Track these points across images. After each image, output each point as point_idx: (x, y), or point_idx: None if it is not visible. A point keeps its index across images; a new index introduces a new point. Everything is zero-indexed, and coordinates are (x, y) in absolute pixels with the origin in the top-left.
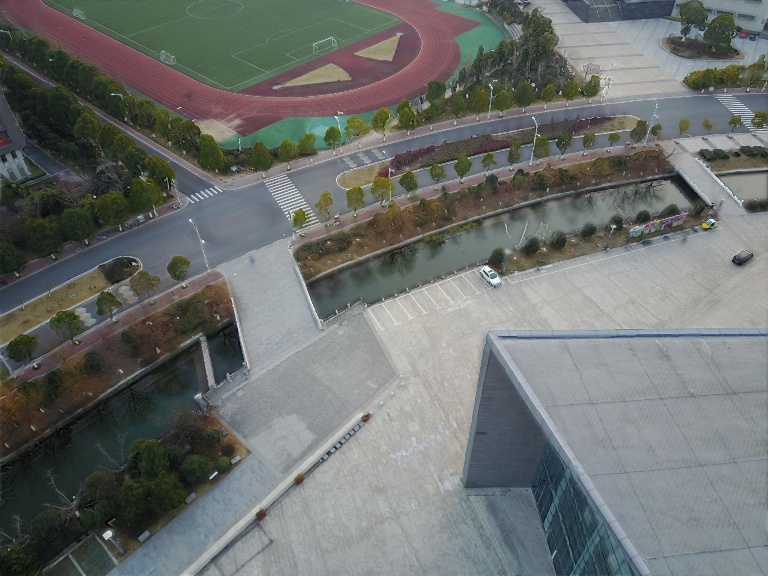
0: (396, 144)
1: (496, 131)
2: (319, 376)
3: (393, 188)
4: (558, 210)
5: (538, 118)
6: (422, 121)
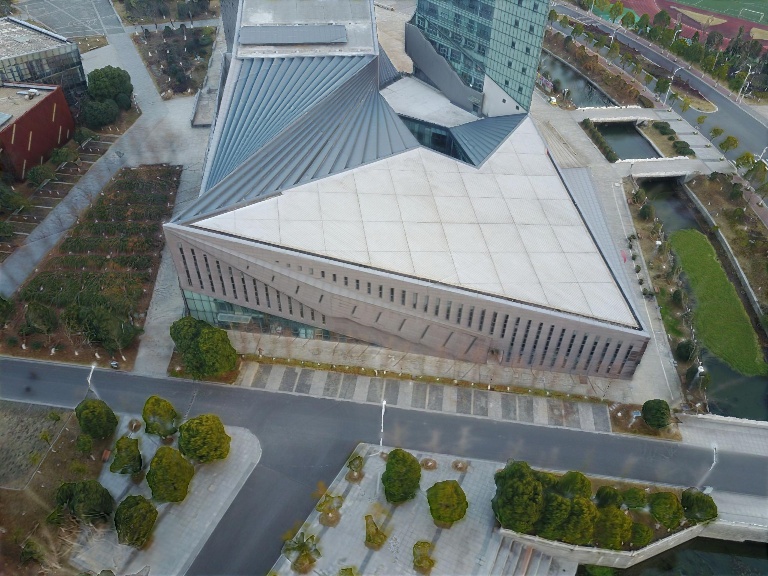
0: (610, 29)
1: (649, 57)
2: (414, 6)
3: (557, 25)
4: (561, 71)
5: (682, 73)
6: (645, 36)
